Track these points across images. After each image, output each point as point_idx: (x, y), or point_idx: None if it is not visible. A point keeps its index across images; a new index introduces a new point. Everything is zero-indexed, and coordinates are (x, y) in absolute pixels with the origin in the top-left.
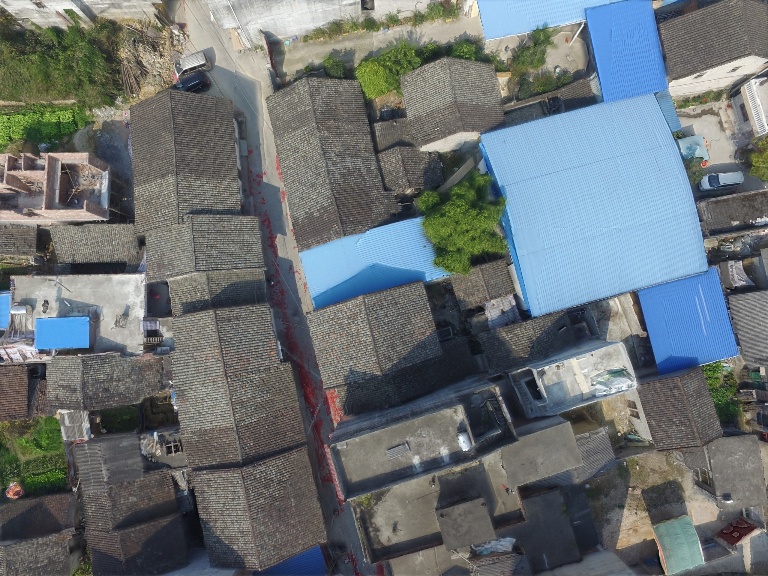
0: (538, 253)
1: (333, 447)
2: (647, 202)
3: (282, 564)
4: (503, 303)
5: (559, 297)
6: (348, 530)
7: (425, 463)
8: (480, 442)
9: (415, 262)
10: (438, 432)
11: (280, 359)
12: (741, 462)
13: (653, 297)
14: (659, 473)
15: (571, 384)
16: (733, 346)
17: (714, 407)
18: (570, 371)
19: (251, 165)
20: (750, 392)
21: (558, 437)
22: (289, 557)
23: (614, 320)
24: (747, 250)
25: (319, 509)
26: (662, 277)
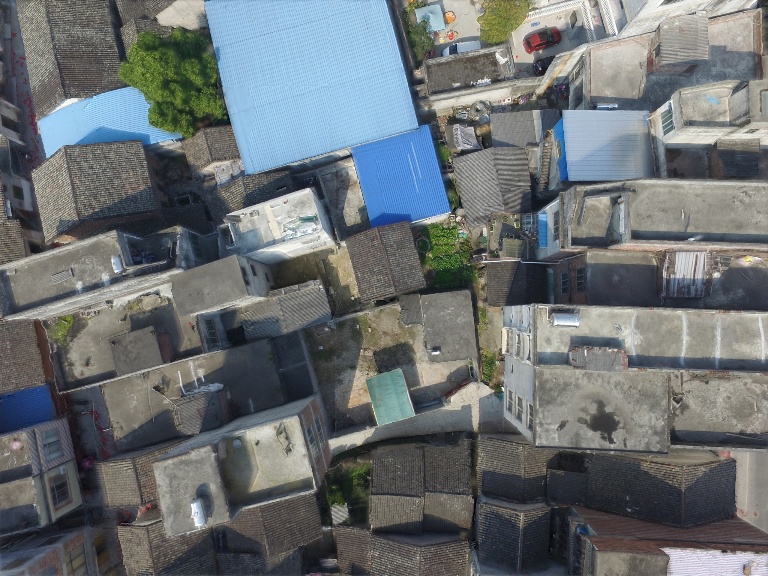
0: (248, 111)
1: (1, 272)
2: (354, 59)
3: (11, 408)
4: (232, 168)
5: (271, 155)
6: (93, 388)
7: (87, 288)
8: (141, 269)
9: (140, 126)
10: (101, 259)
11: (8, 216)
12: (453, 317)
13: (366, 155)
14: (391, 336)
15: (265, 231)
16: (445, 203)
17: (418, 259)
18: (264, 219)
19: (14, 48)
20: (481, 256)
21: (224, 269)
22: (18, 402)
23: (353, 189)
24: (486, 119)
25: (39, 354)
26: (372, 135)
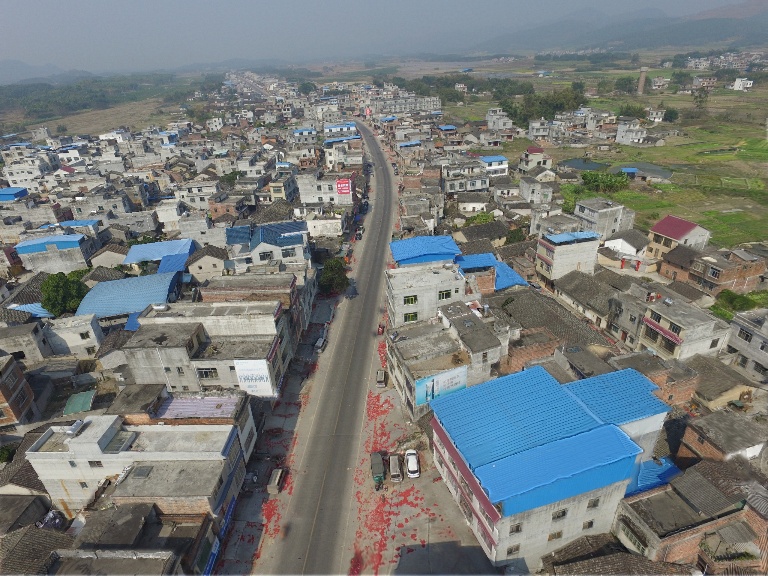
0: None
1: None
2: None
3: None
4: None
5: None
6: None
7: None
8: None
9: (37, 312)
10: None
11: None
12: None
13: None
14: None
15: None
16: None
17: None
18: None
19: None
20: None
21: None
22: None
23: None
24: None
25: None
26: None
